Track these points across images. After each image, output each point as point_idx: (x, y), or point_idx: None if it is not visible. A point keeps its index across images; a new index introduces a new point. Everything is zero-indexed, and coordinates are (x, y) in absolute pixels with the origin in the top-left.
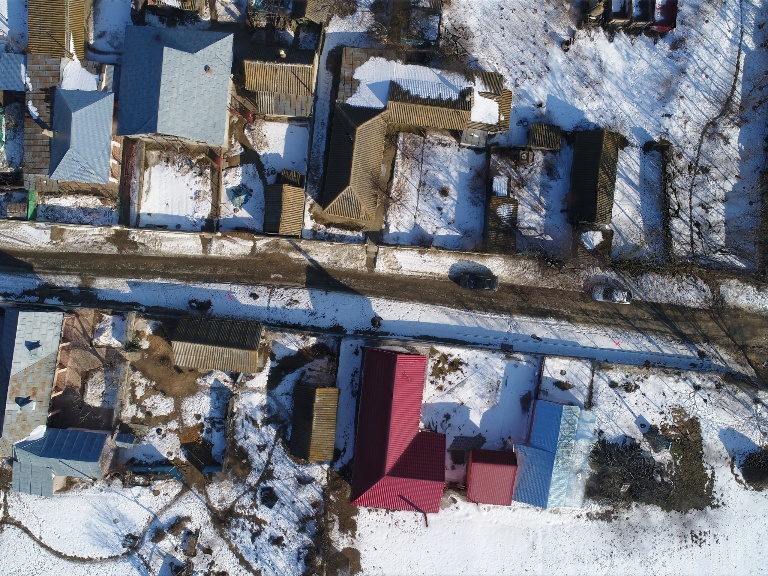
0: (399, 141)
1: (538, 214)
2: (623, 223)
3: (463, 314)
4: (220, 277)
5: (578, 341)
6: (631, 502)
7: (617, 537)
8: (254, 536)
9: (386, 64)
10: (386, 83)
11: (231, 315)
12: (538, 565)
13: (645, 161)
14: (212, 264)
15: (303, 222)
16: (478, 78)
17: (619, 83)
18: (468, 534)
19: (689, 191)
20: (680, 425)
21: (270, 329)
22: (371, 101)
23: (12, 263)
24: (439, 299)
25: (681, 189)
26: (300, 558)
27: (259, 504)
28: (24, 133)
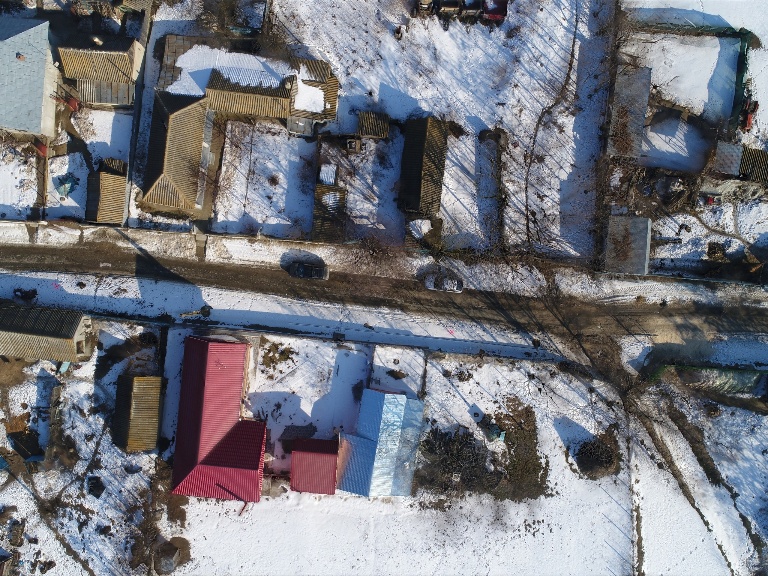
0: (227, 129)
1: (371, 203)
2: (458, 212)
3: (295, 303)
4: (48, 266)
5: (411, 330)
6: (465, 491)
7: (450, 526)
8: (81, 526)
9: (209, 52)
10: (208, 71)
11: (57, 304)
12: (370, 554)
13: (480, 150)
14: (39, 253)
15: (129, 211)
16: (303, 66)
17: (454, 72)
18: (299, 523)
19: (525, 180)
20: (514, 414)
21: (96, 318)
22: (191, 89)
23: None
24: (271, 288)
25: (517, 178)
26: (127, 547)
27: (86, 493)
28: None
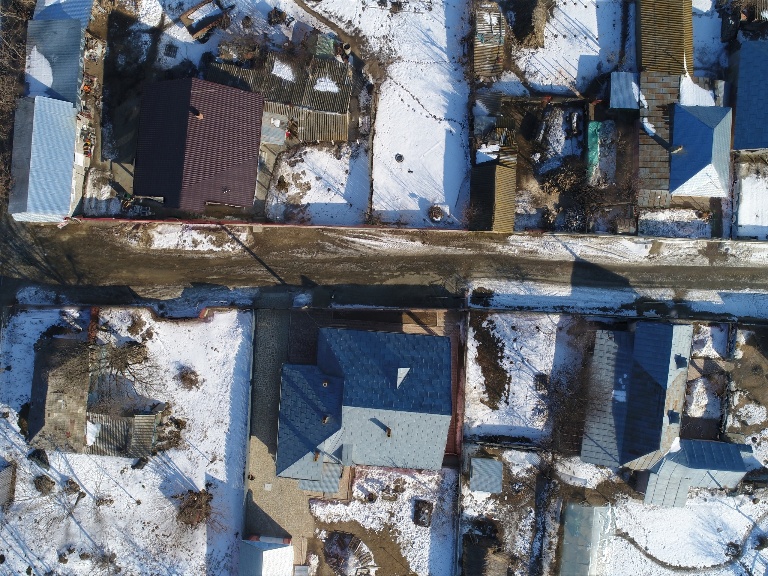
0: None
1: None
2: None
3: None
4: None
5: None
6: None
7: None
8: None
9: None
10: None
11: None
12: None
13: None
14: None
15: None
16: None
17: None
18: None
19: None
20: None
21: None
22: None
23: (610, 278)
24: None
25: None
26: None
27: None
28: (639, 150)
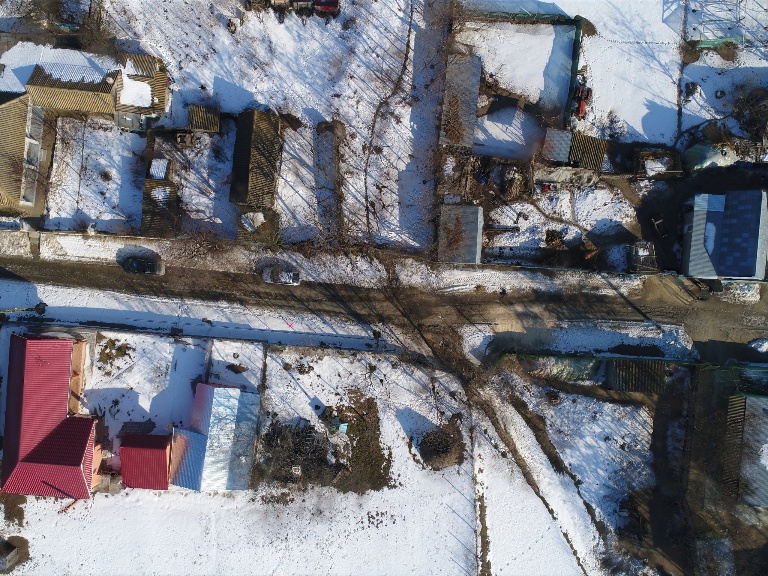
0: (58, 126)
1: (207, 197)
2: (297, 204)
3: (133, 299)
4: None
5: (250, 324)
6: (307, 484)
7: (293, 520)
8: None
9: (34, 48)
10: (31, 67)
11: None
12: (212, 550)
13: (319, 142)
14: None
15: None
16: (130, 61)
17: (290, 64)
18: (139, 520)
19: (364, 171)
20: (356, 406)
21: None
22: (13, 86)
23: None
24: (108, 284)
25: (356, 169)
26: None
27: None
28: None
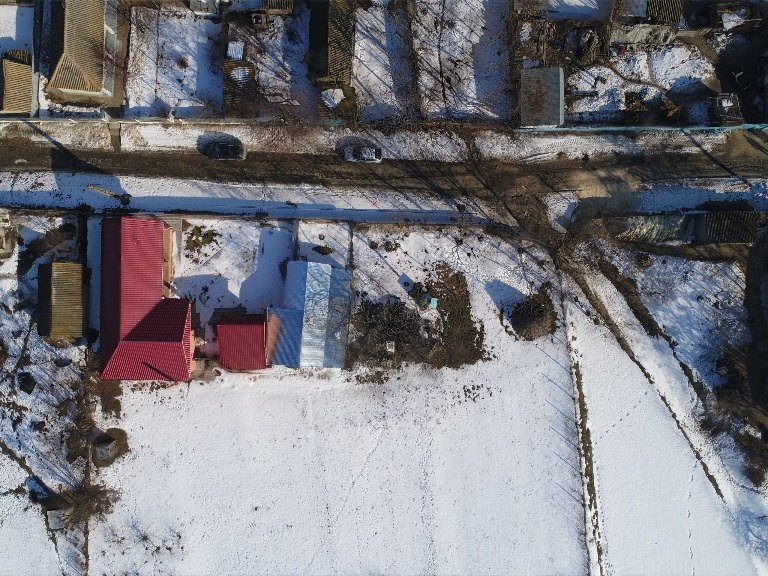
0: (132, 15)
1: (283, 80)
2: (373, 84)
3: (215, 186)
4: None
5: (334, 204)
6: (401, 362)
7: (389, 398)
8: (15, 423)
9: None
10: None
11: None
12: (310, 432)
13: (390, 20)
14: None
15: (38, 102)
16: None
17: None
18: (235, 406)
19: (437, 47)
20: (445, 281)
21: (14, 213)
22: None
23: None
24: (190, 173)
25: (429, 45)
26: (62, 441)
27: (17, 390)
28: None
